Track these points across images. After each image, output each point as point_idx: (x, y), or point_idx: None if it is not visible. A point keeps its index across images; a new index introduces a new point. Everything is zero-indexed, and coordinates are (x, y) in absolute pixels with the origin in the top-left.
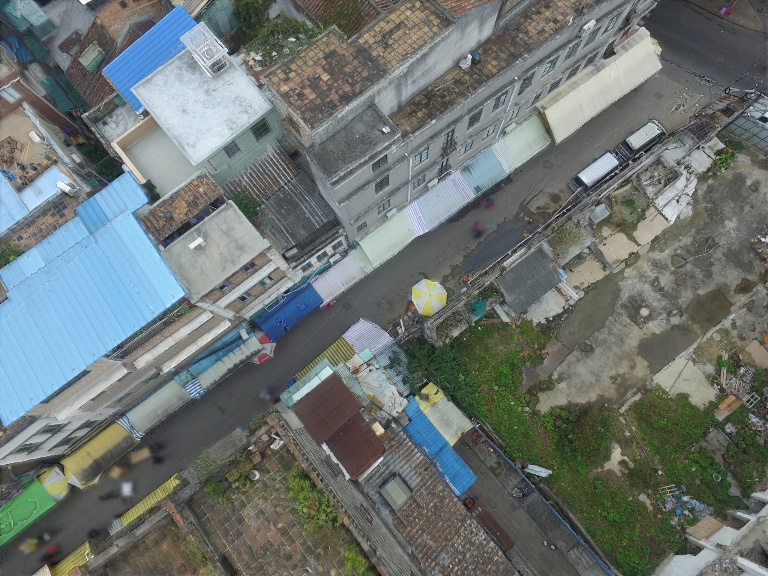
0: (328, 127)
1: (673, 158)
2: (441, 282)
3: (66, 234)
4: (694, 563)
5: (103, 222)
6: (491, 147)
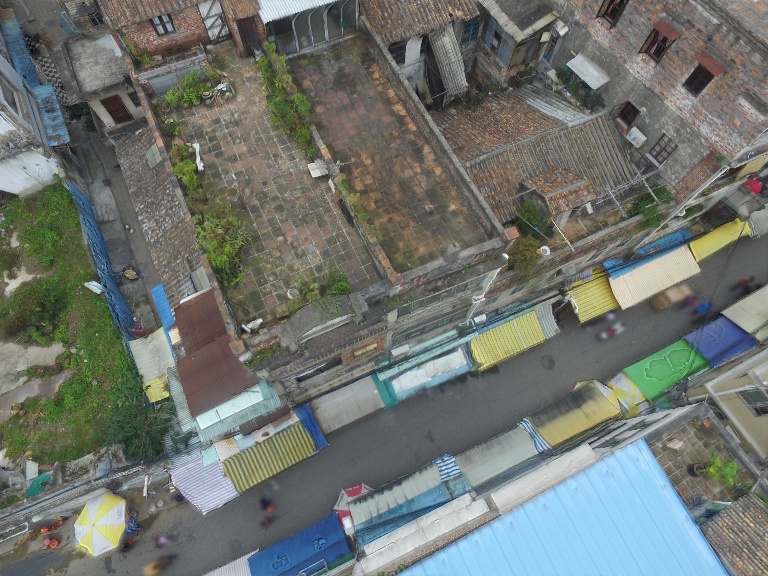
0: None
1: None
2: None
3: None
4: None
5: None
6: None
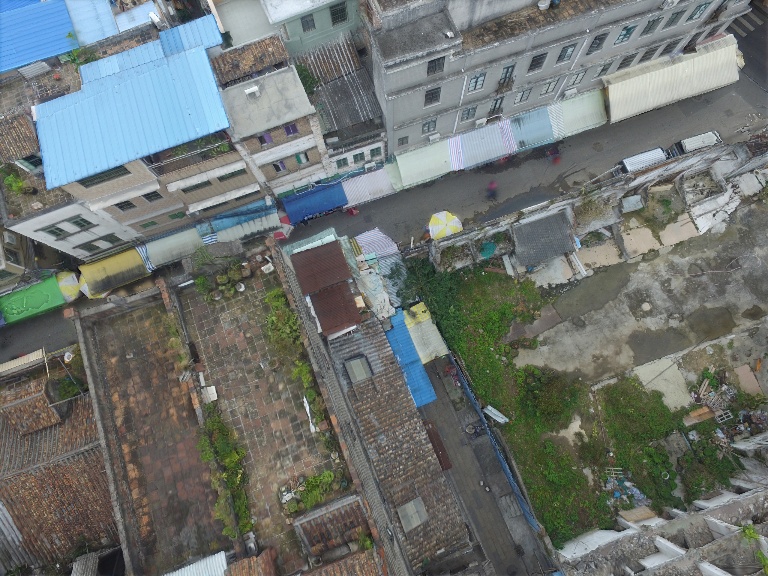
0: (399, 15)
1: (722, 172)
2: None
3: (145, 52)
4: (615, 536)
5: (179, 50)
6: (547, 107)
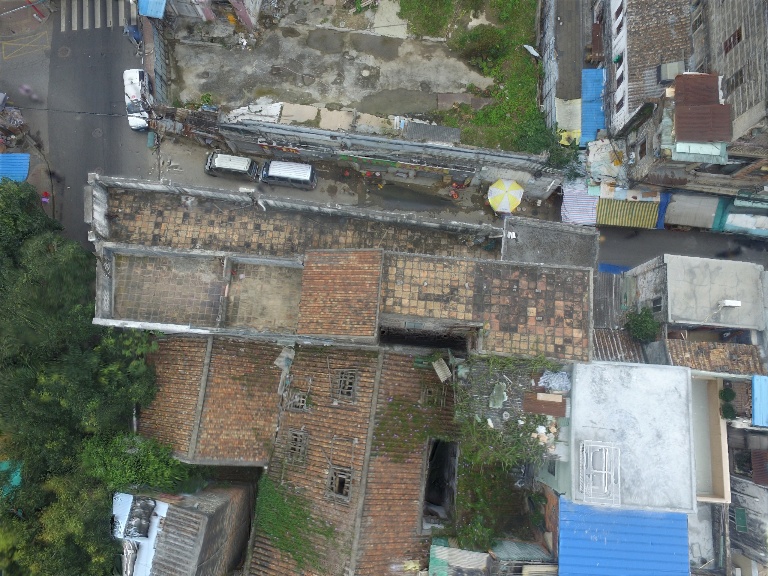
0: None
1: None
2: (474, 211)
3: None
4: None
5: None
6: None
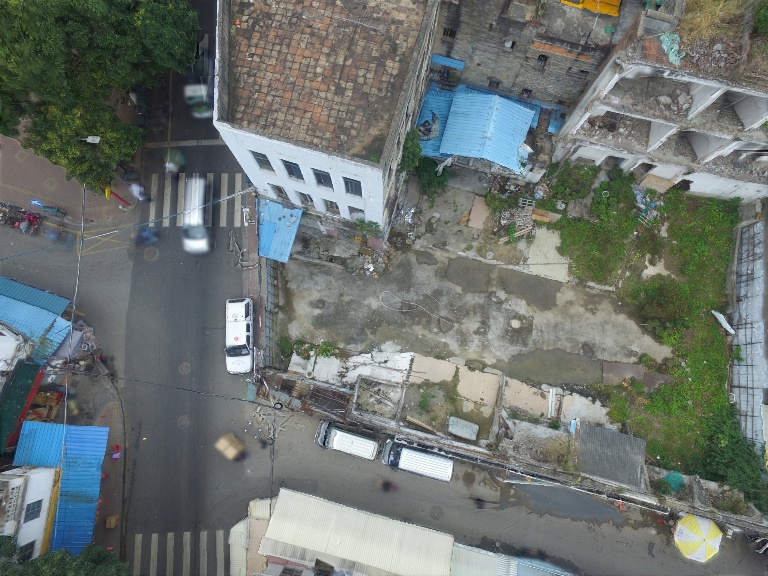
0: None
1: None
2: (643, 528)
3: None
4: (704, 181)
5: None
6: None
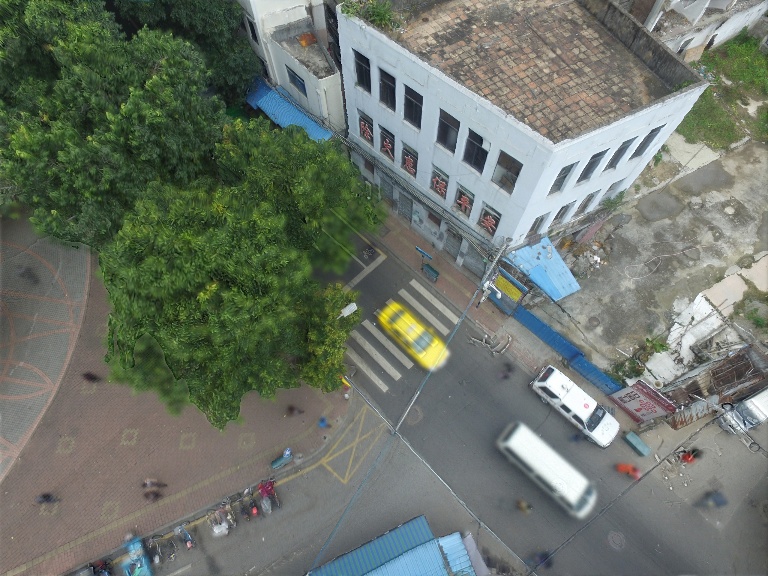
0: None
1: None
2: None
3: None
4: None
5: None
6: None
